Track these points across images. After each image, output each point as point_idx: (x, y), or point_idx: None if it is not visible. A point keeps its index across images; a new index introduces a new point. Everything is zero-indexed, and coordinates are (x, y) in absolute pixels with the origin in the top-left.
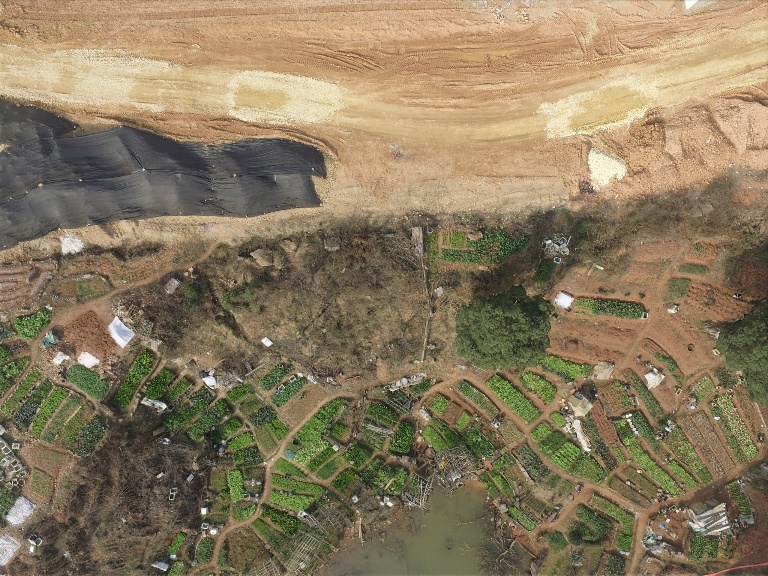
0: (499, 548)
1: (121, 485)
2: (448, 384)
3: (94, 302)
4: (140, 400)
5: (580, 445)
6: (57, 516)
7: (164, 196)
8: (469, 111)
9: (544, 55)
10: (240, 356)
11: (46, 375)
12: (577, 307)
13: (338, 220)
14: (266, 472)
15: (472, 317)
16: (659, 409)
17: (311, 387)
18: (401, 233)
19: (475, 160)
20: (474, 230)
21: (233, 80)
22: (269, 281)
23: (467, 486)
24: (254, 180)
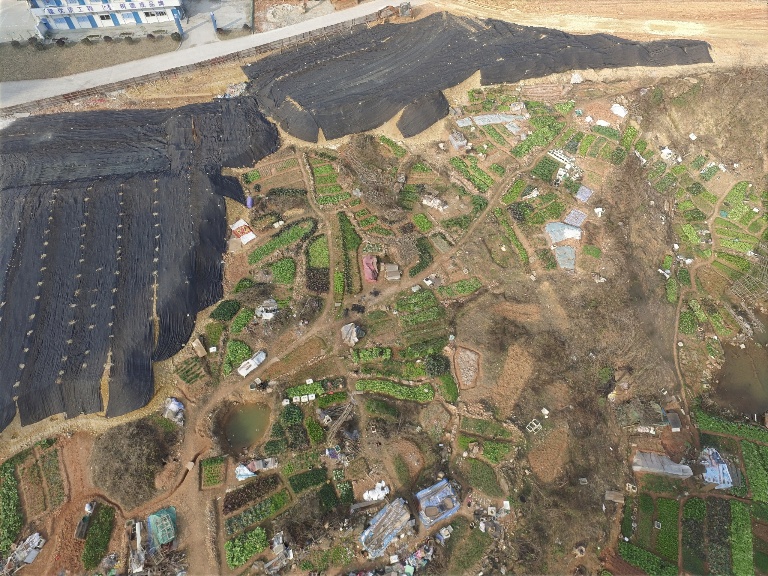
0: None
1: None
2: None
3: (598, 100)
4: None
5: None
6: (608, 199)
7: (629, 56)
8: None
9: None
10: None
11: (578, 130)
12: None
13: (725, 68)
14: (709, 228)
15: None
16: None
17: (721, 174)
18: None
19: None
20: None
21: (645, 23)
22: None
23: None
24: None
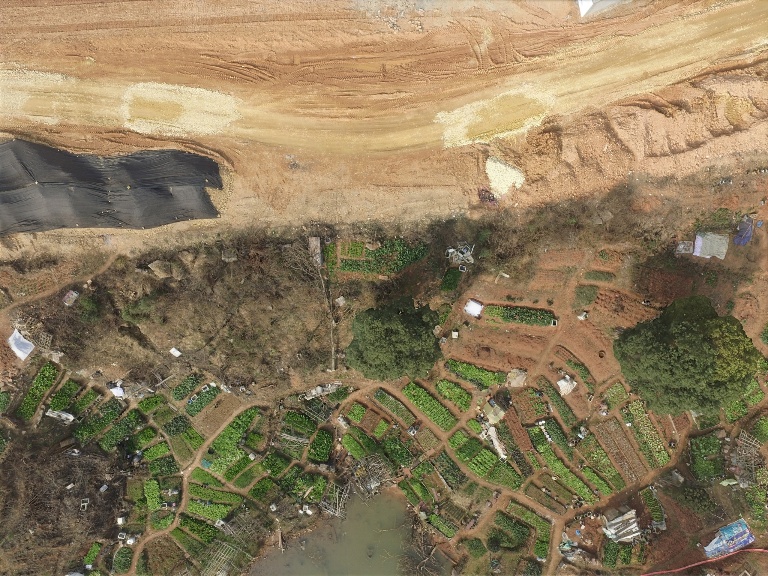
0: (420, 555)
1: (27, 497)
2: (364, 392)
3: None
4: (45, 412)
5: (497, 452)
6: None
7: (59, 209)
8: (365, 121)
9: (439, 64)
10: (148, 367)
11: None
12: (487, 315)
13: (236, 231)
14: (183, 481)
15: (359, 328)
16: (572, 416)
17: (225, 396)
18: (297, 244)
19: (372, 170)
20: (372, 240)
21: (127, 92)
22: (169, 292)
23: (387, 493)
24: (148, 192)
